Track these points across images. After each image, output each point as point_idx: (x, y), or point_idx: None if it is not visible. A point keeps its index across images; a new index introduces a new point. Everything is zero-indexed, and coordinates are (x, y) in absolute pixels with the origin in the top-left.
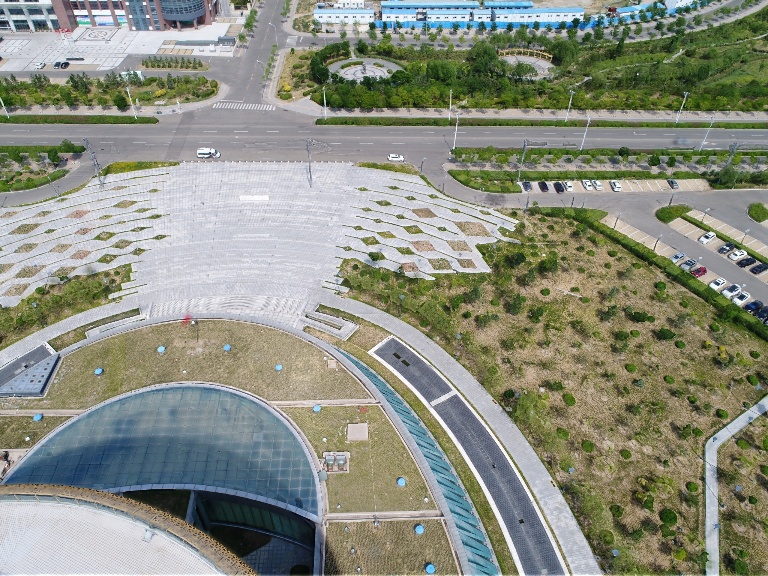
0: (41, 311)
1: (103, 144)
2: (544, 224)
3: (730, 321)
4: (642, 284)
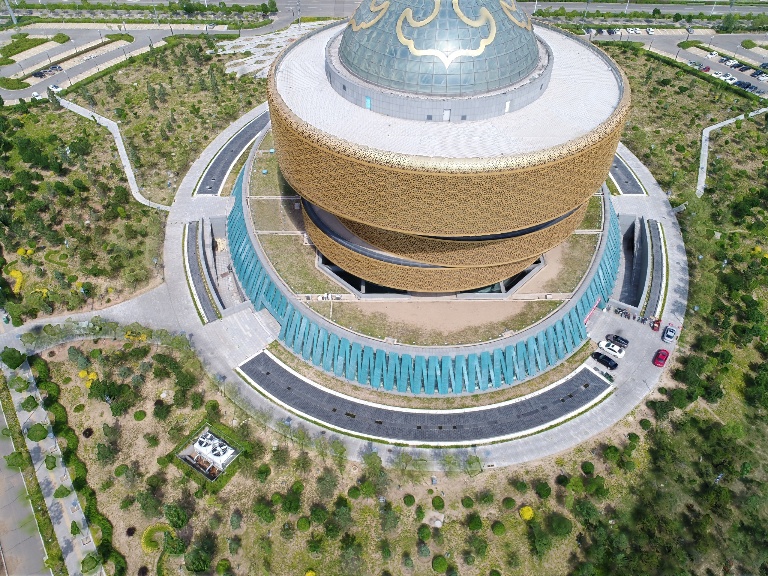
0: None
1: (288, 8)
2: (602, 48)
3: (723, 89)
4: (668, 73)
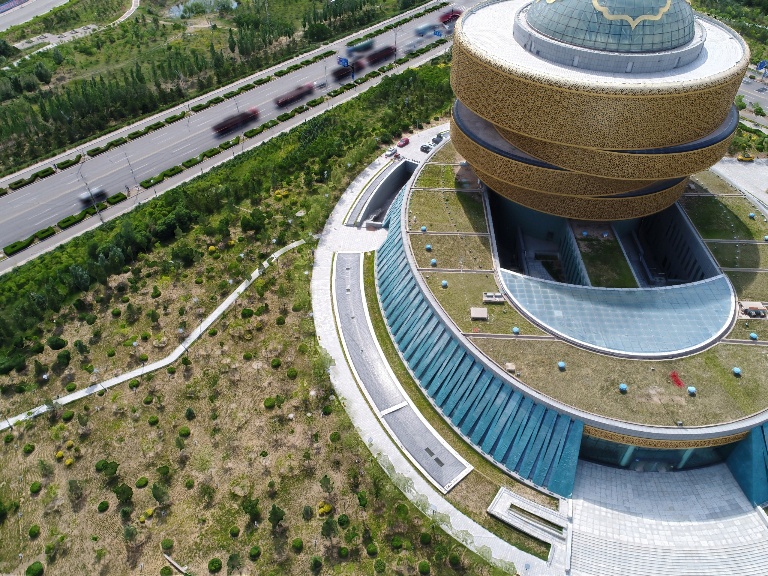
0: None
1: None
2: None
3: None
4: None
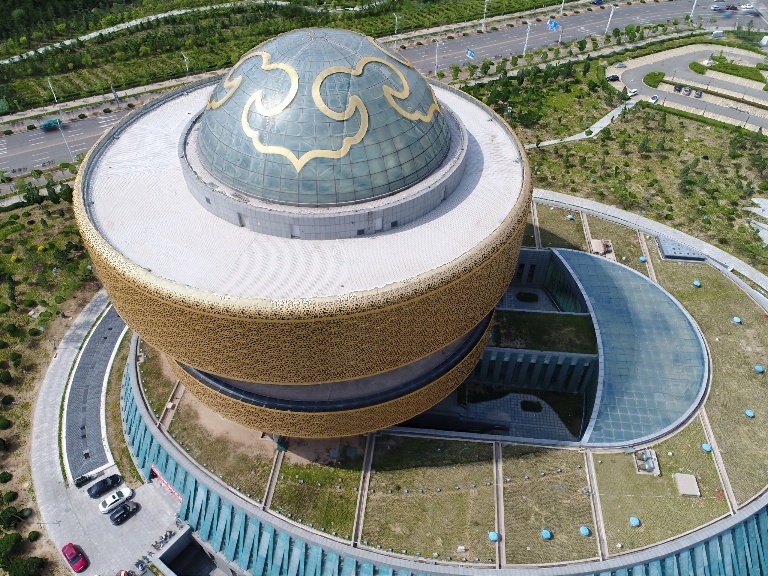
0: (762, 254)
1: None
2: None
3: None
4: None
